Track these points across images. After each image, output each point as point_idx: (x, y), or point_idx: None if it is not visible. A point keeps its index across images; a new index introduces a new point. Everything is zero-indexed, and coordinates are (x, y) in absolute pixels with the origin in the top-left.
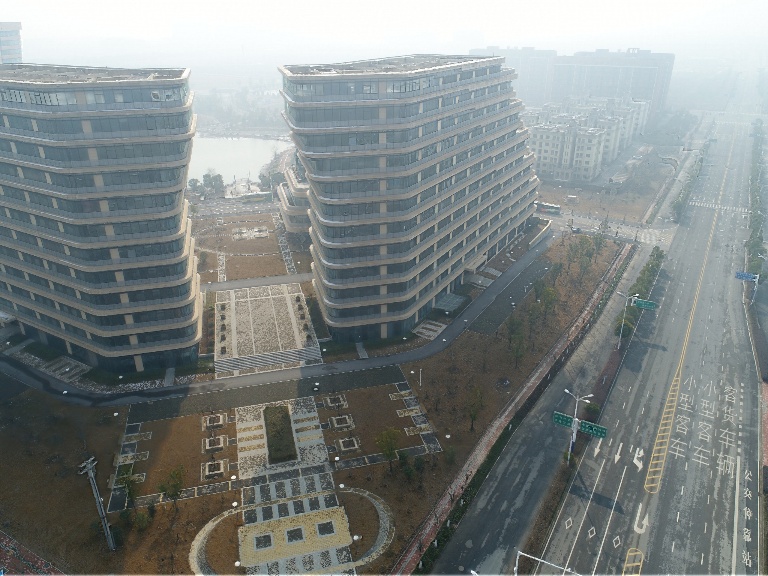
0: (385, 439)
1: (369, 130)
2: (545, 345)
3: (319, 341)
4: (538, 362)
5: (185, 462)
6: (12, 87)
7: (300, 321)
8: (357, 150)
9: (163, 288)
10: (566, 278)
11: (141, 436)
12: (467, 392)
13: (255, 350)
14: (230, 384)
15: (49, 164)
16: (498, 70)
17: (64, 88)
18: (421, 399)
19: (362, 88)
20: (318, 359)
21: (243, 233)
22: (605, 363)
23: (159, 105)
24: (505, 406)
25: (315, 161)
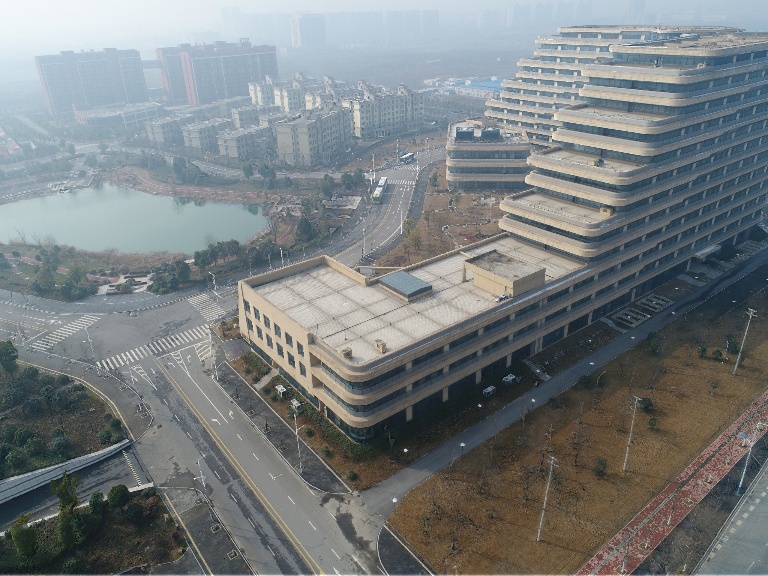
0: None
1: None
2: None
3: None
4: None
5: None
6: None
7: None
8: None
9: None
10: None
11: None
12: None
13: None
14: None
15: None
16: None
17: None
18: None
19: None
20: None
21: (486, 203)
22: None
23: None
24: None
25: None
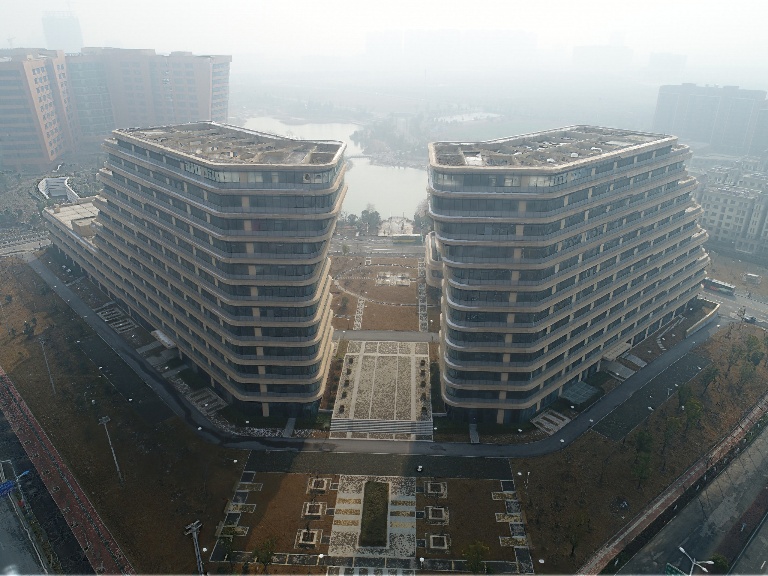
0: (471, 554)
1: (506, 222)
2: (679, 465)
3: (433, 415)
4: (667, 485)
5: (284, 524)
6: (192, 161)
7: (420, 389)
8: (492, 240)
9: (294, 347)
10: (723, 382)
11: (253, 486)
12: (576, 507)
13: (371, 414)
14: (341, 447)
15: (212, 229)
16: (667, 151)
17: (231, 168)
18: (524, 505)
19: (504, 181)
20: (429, 435)
21: (387, 278)
22: (750, 502)
23: (308, 187)
24: (616, 534)
25: (448, 246)
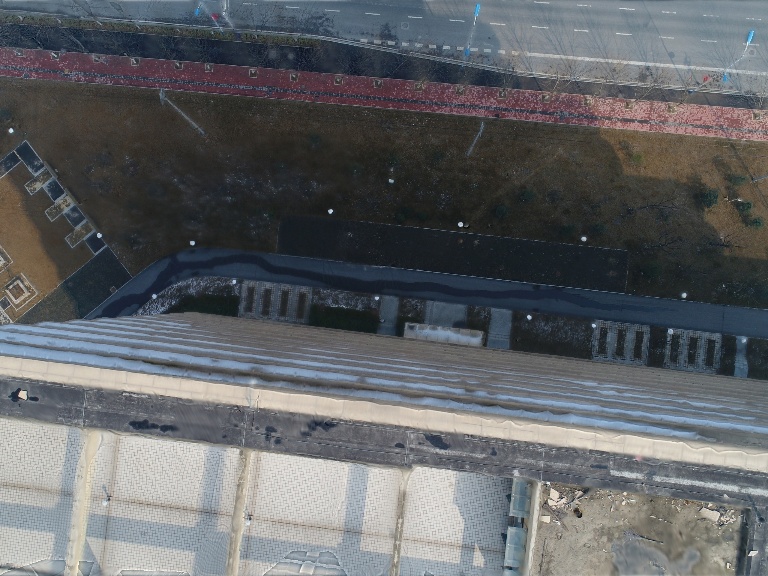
0: None
1: None
2: None
3: None
4: None
5: (2, 223)
6: None
7: None
8: None
9: None
10: None
11: (77, 237)
12: None
13: None
14: None
15: None
16: None
17: None
18: None
19: None
20: None
21: None
22: None
23: None
24: None
25: None
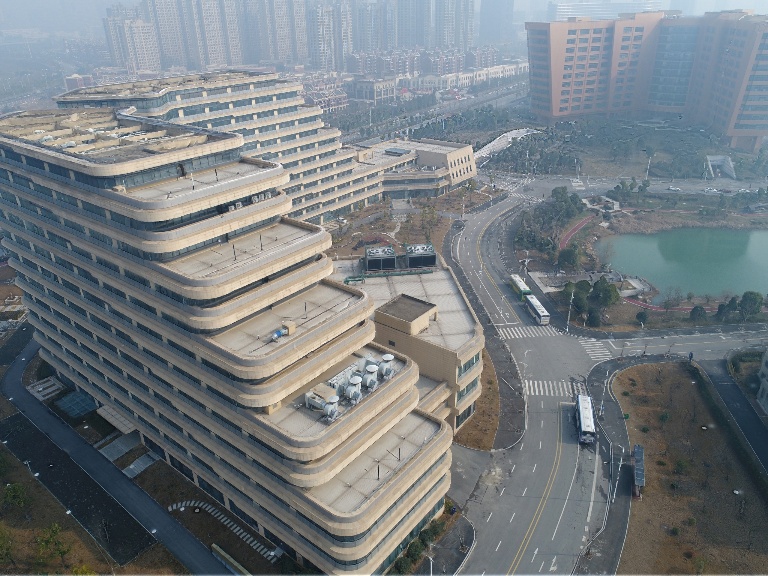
0: None
1: None
2: None
3: None
4: None
5: None
6: None
7: None
8: None
9: None
10: None
11: None
12: None
13: None
14: None
15: None
16: (96, 183)
17: None
18: None
19: None
20: None
21: None
22: None
23: None
24: None
25: None
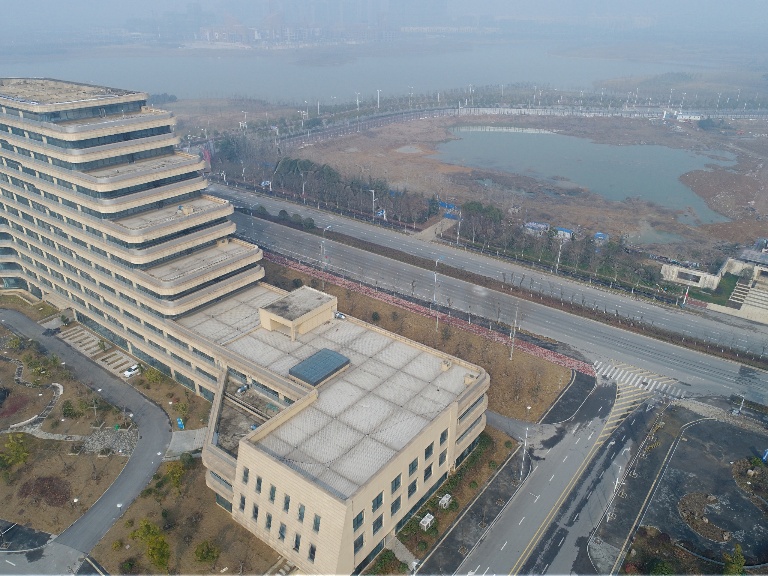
0: None
1: None
2: None
3: None
4: None
5: None
6: None
7: None
8: None
9: None
10: None
11: None
12: None
13: None
14: None
15: None
16: None
17: None
18: None
19: None
20: None
21: None
22: None
23: None
24: None
25: None
